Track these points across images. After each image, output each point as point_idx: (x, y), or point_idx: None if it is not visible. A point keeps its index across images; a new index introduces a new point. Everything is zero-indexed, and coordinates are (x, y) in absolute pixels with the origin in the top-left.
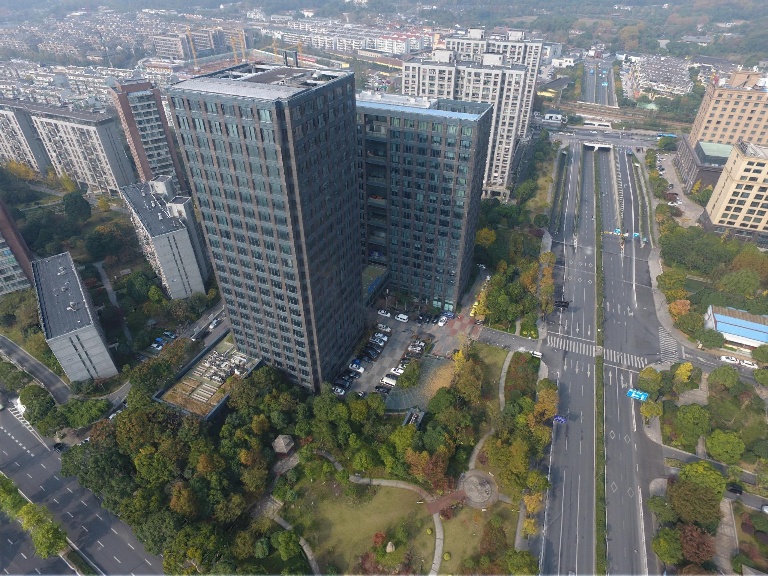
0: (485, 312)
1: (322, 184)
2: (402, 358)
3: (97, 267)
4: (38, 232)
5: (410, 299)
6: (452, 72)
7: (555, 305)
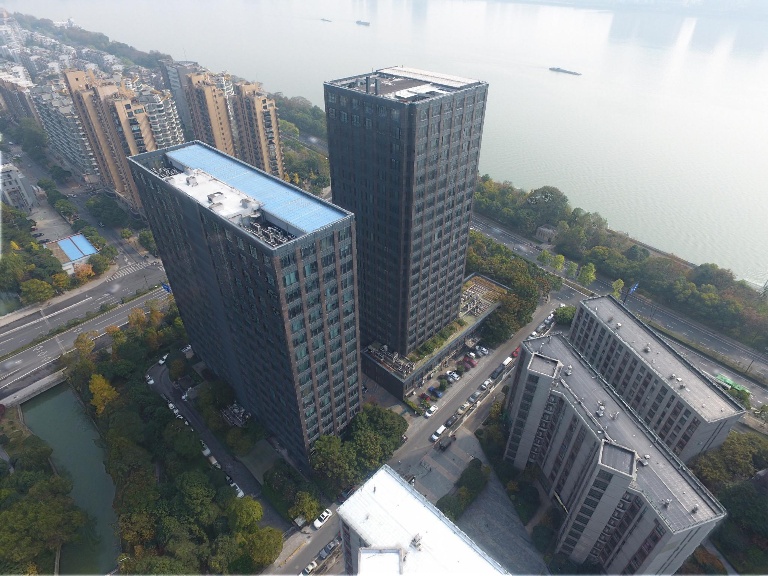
0: None
1: None
2: None
3: (735, 571)
4: None
5: None
6: None
7: None
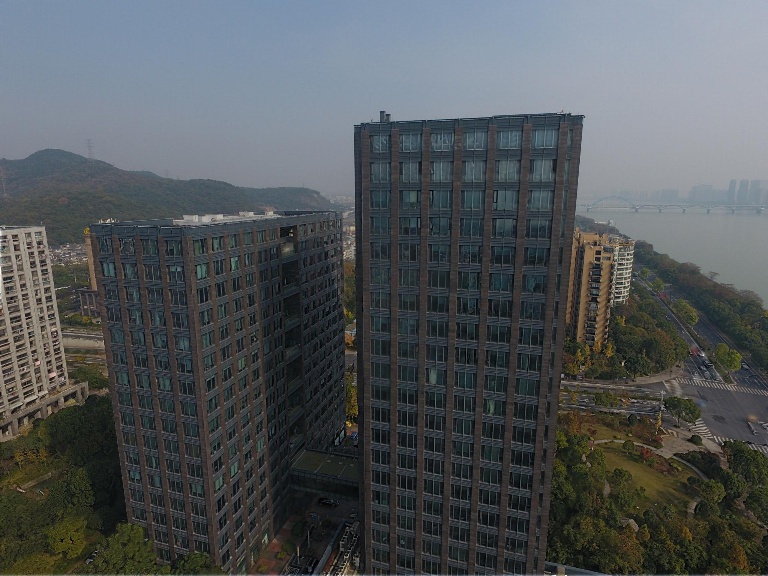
0: None
1: None
2: None
3: None
4: None
5: None
6: None
7: None
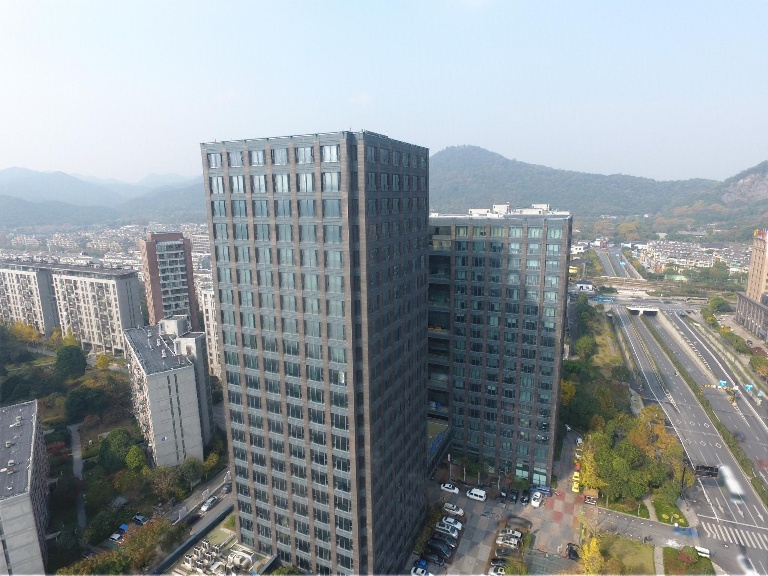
0: (598, 484)
1: (392, 266)
2: (491, 558)
3: (71, 430)
4: (14, 388)
5: (484, 467)
6: None
7: (696, 473)
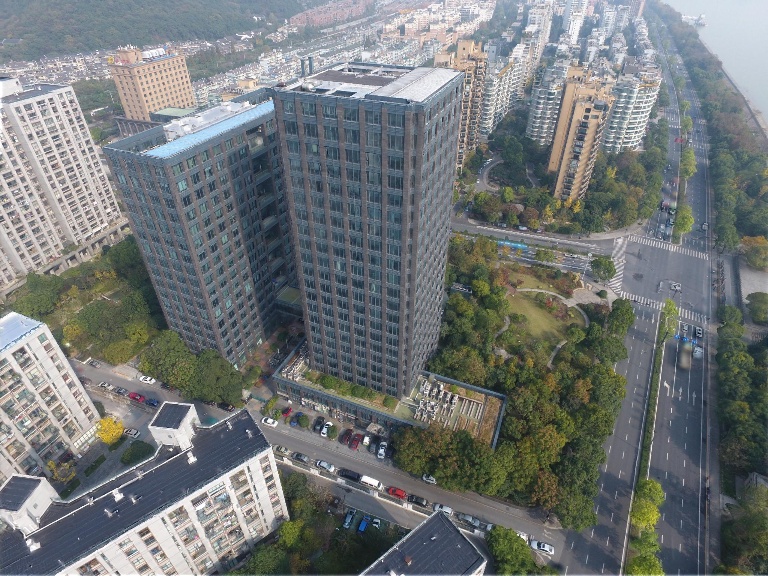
0: None
1: None
2: None
3: None
4: None
5: None
6: None
7: None
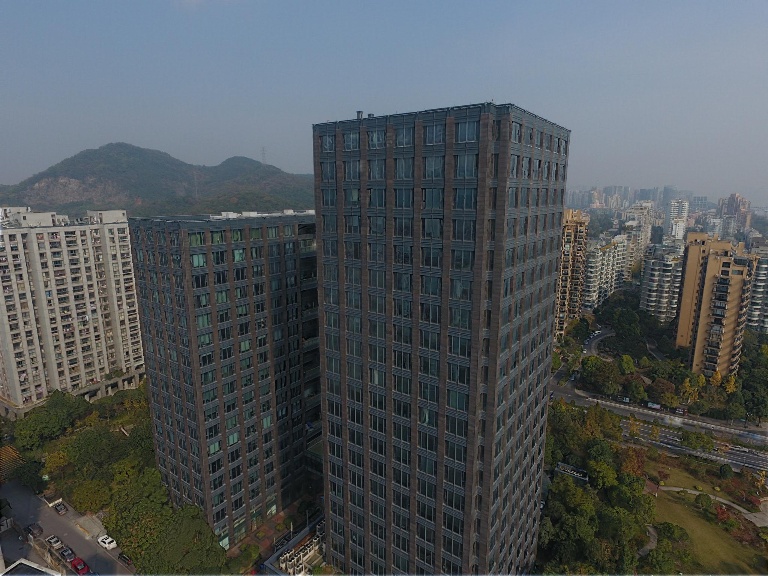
0: None
1: None
2: None
3: None
4: None
5: None
6: (86, 232)
7: None
